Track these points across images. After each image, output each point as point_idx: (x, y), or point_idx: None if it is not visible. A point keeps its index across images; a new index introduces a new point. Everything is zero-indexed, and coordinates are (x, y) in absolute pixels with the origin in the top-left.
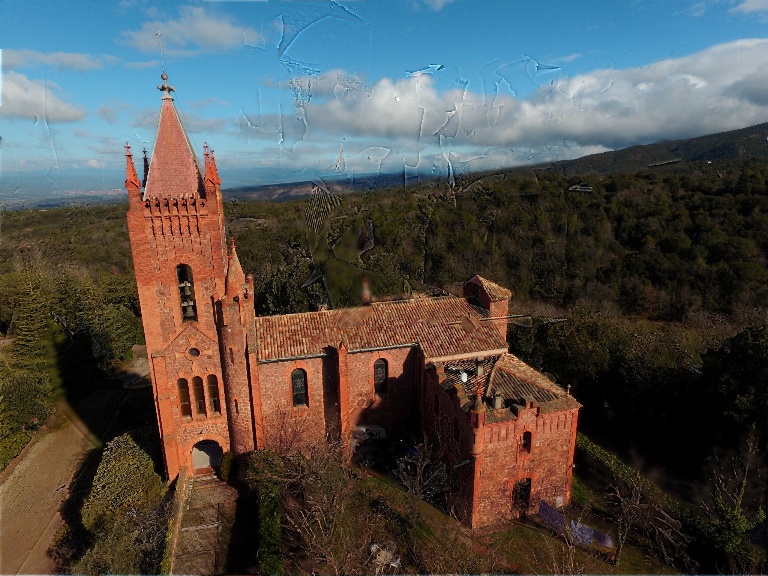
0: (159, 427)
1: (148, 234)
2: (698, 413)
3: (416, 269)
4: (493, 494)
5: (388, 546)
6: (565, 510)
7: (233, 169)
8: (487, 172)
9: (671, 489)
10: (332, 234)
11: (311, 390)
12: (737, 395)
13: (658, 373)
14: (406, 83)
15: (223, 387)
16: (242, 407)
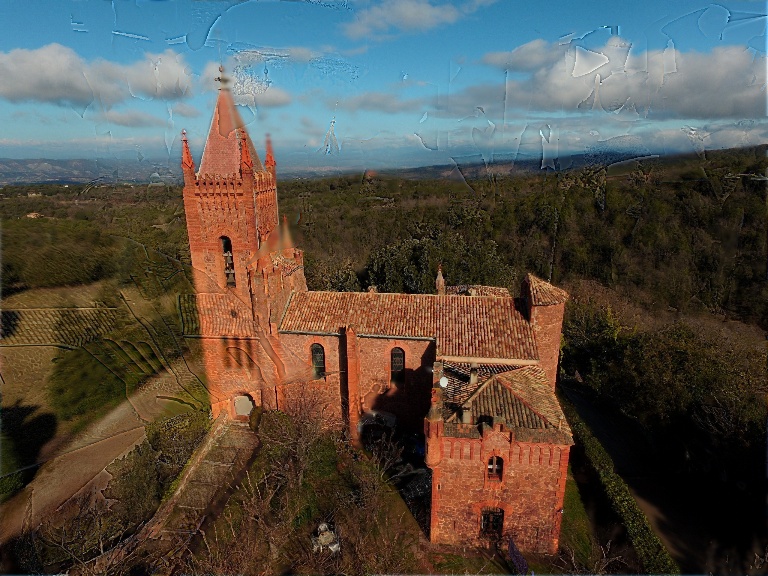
0: None
1: (198, 208)
2: None
3: None
4: (456, 513)
5: (336, 529)
6: (549, 558)
7: (371, 149)
8: (629, 153)
9: None
10: (467, 217)
11: (328, 366)
12: None
13: (740, 430)
14: (559, 52)
15: None
16: None
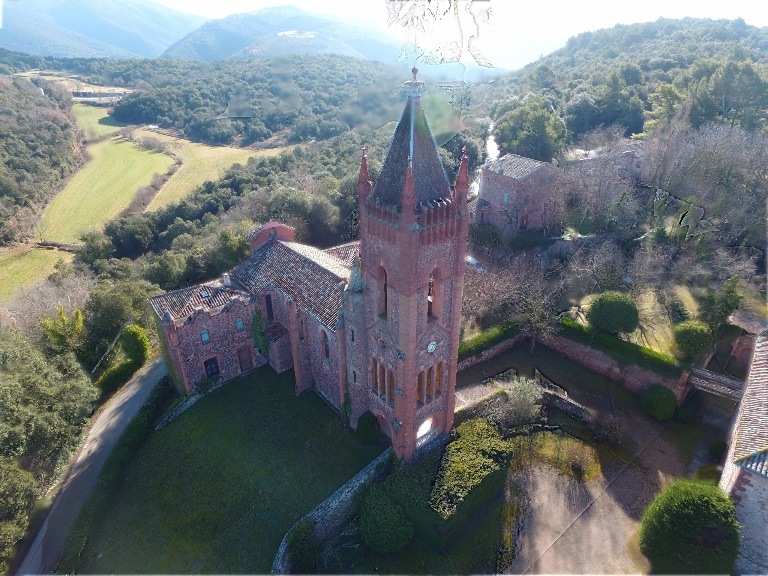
0: None
1: None
2: None
3: None
4: None
5: None
6: None
7: None
8: None
9: None
10: None
11: None
12: None
13: None
14: None
15: None
16: None
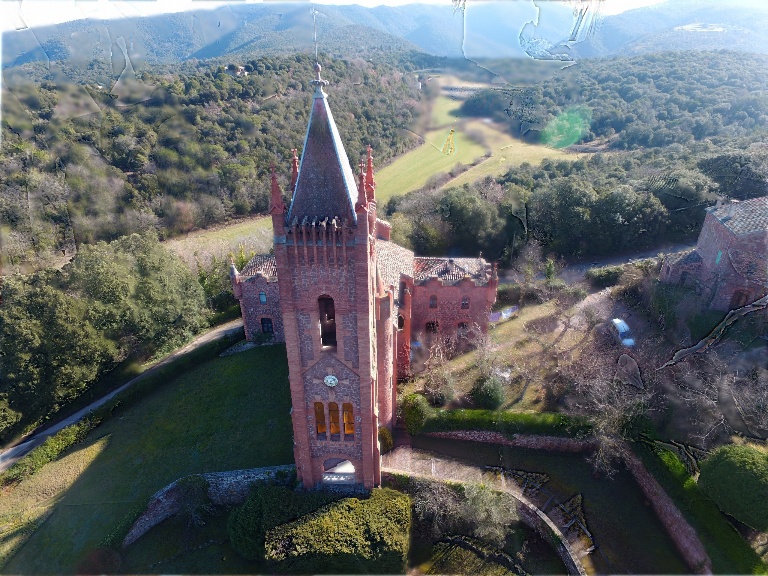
0: (372, 446)
1: None
2: None
3: (7, 256)
4: None
5: None
6: None
7: None
8: (158, 117)
9: None
10: None
11: None
12: None
13: None
14: None
15: (377, 377)
16: None
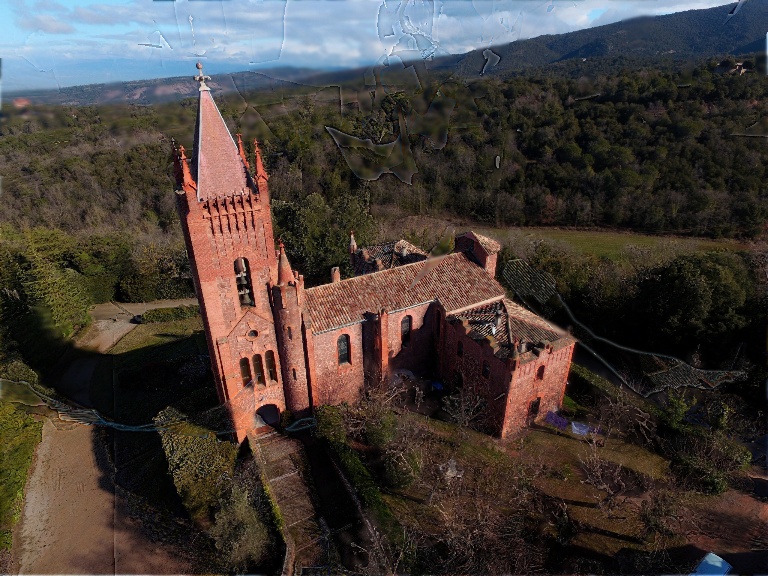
0: None
1: (207, 234)
2: (637, 328)
3: None
4: (516, 413)
5: (450, 464)
6: (559, 413)
7: (155, 100)
8: None
9: (623, 386)
10: (266, 165)
11: (353, 350)
12: (671, 317)
13: (612, 302)
14: None
15: (279, 359)
16: (299, 374)
